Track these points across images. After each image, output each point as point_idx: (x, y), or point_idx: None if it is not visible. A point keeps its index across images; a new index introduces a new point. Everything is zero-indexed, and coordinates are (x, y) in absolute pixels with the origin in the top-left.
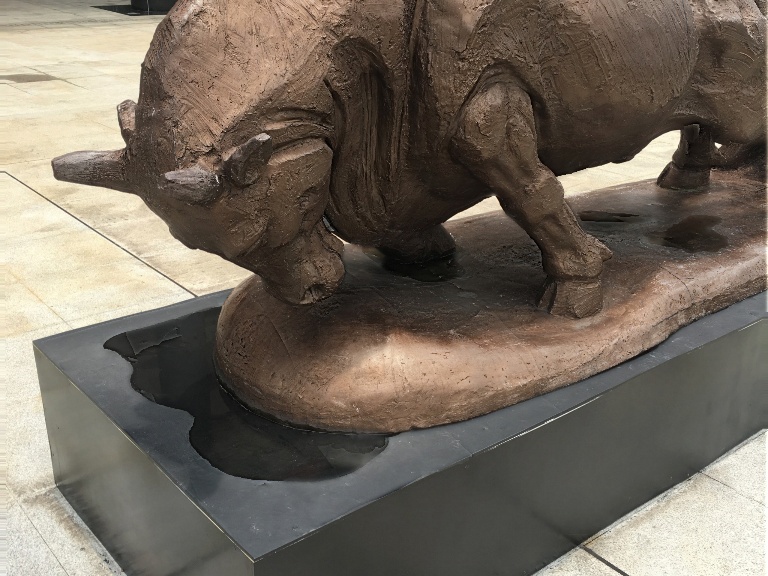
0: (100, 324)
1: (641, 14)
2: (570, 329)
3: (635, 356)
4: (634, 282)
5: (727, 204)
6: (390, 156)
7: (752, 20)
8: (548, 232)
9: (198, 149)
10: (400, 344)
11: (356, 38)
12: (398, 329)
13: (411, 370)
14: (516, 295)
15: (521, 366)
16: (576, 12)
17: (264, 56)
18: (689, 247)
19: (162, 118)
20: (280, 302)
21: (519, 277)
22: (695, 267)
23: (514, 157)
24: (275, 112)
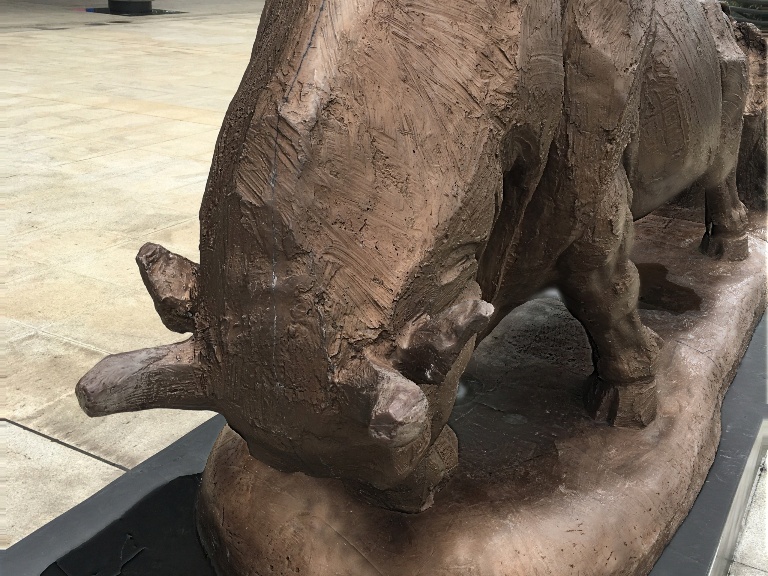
0: (8, 555)
1: (704, 61)
2: (647, 444)
3: (713, 462)
4: (664, 365)
5: (652, 246)
6: (499, 275)
7: (740, 57)
8: (619, 332)
9: (361, 335)
10: (527, 528)
11: (522, 125)
12: (511, 504)
13: (556, 565)
14: (562, 407)
15: (646, 516)
16: (665, 63)
17: (425, 167)
18: (670, 307)
19: (294, 290)
20: (324, 488)
21: (547, 380)
22: (702, 334)
23: (617, 253)
24: (447, 254)
